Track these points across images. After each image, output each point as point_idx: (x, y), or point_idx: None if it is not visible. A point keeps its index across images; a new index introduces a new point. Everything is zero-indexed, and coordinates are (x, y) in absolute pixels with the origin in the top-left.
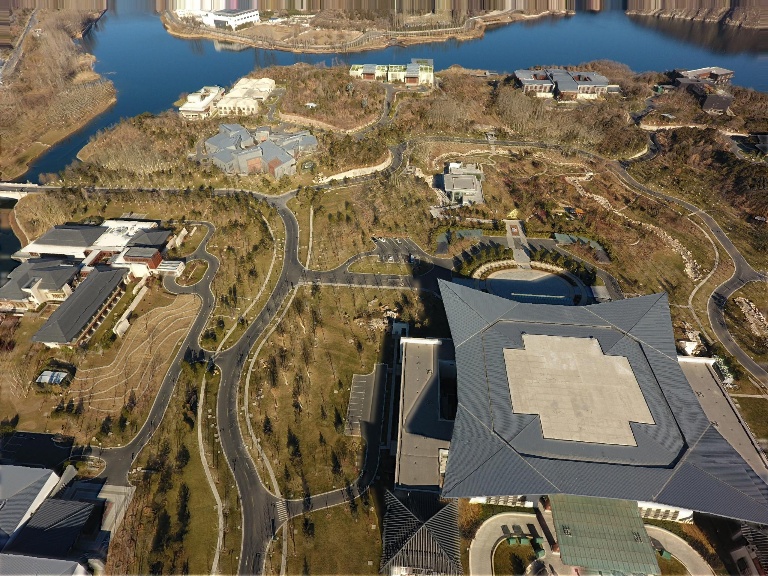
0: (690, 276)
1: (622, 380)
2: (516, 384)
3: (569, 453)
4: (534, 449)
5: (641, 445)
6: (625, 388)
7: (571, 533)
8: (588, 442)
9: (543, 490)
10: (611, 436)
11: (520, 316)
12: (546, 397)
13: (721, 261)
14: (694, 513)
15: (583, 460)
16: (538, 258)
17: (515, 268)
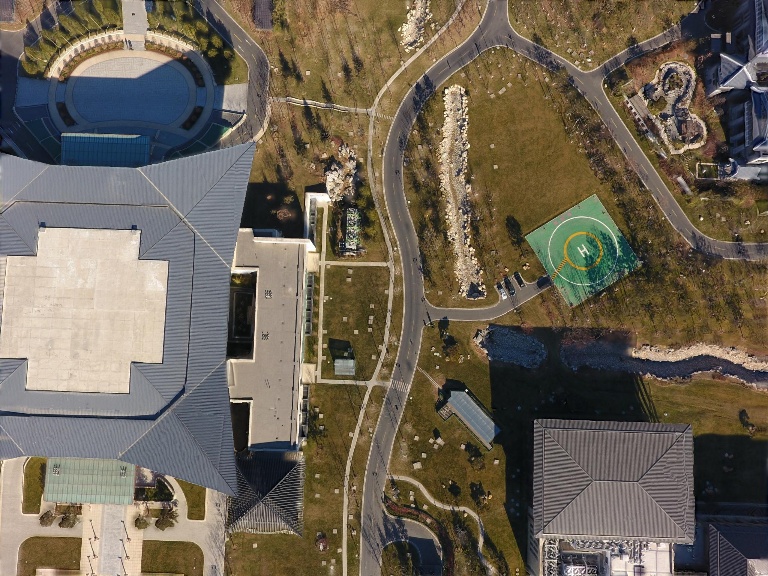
0: (405, 40)
1: (146, 301)
2: (10, 315)
3: (49, 407)
4: (12, 404)
5: (132, 393)
6: (145, 313)
7: (59, 472)
8: (75, 392)
9: (3, 456)
10: (103, 383)
11: (44, 193)
12: (42, 333)
13: (468, 2)
14: (234, 415)
15: (63, 414)
16: (155, 25)
17: (118, 49)
